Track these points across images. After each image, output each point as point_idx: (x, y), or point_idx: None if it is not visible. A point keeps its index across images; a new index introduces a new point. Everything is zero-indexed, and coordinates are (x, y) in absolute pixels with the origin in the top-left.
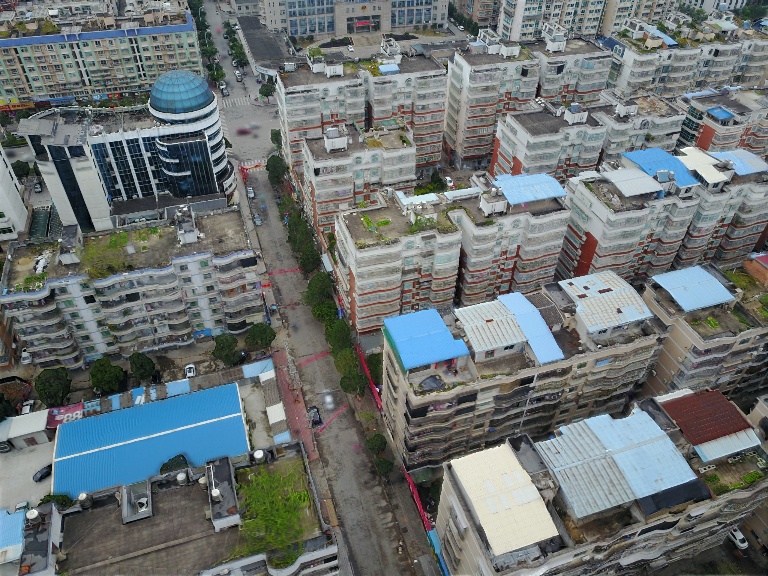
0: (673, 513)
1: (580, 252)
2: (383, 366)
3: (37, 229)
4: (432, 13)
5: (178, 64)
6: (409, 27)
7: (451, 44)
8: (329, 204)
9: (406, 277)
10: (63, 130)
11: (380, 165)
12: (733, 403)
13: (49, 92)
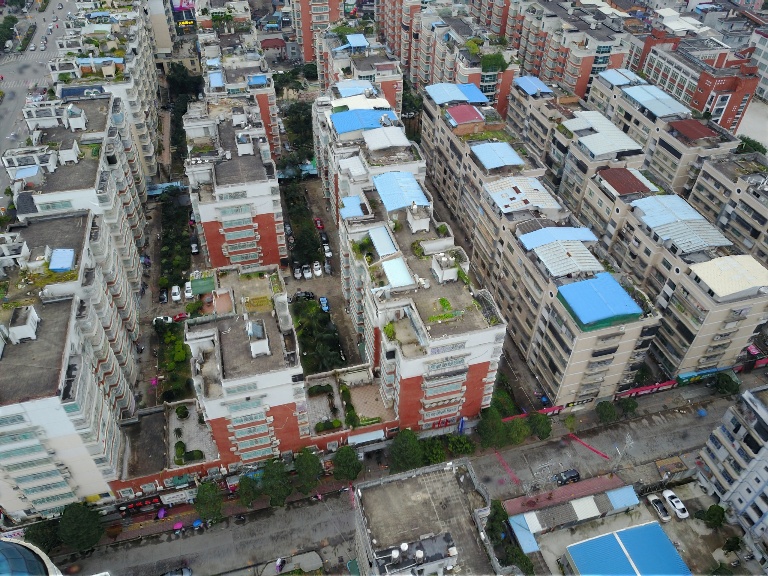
0: None
1: None
2: (574, 365)
3: None
4: None
5: None
6: None
7: None
8: None
9: None
10: None
11: None
12: None
13: None
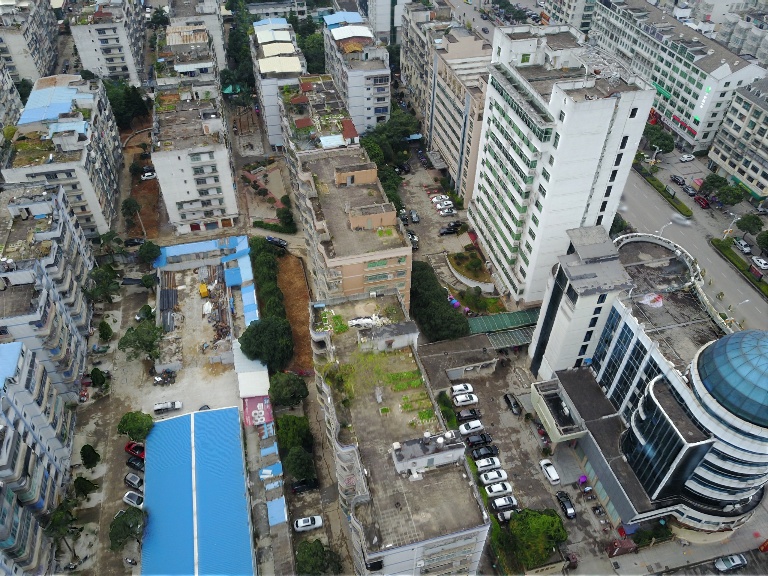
0: None
1: None
2: None
3: None
4: None
5: None
6: None
7: None
8: None
9: None
10: (606, 268)
11: None
12: None
13: None
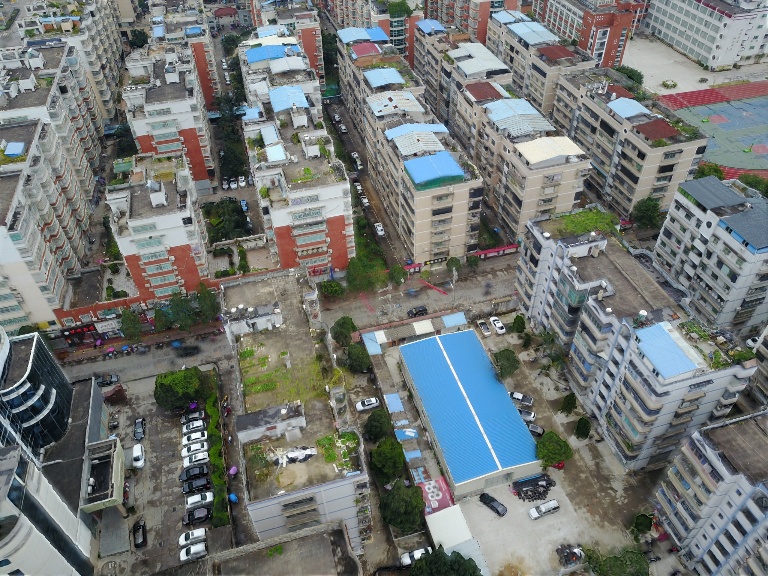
0: (540, 111)
1: None
2: (419, 223)
3: None
4: None
5: None
6: None
7: None
8: None
9: None
10: None
11: None
12: None
13: None
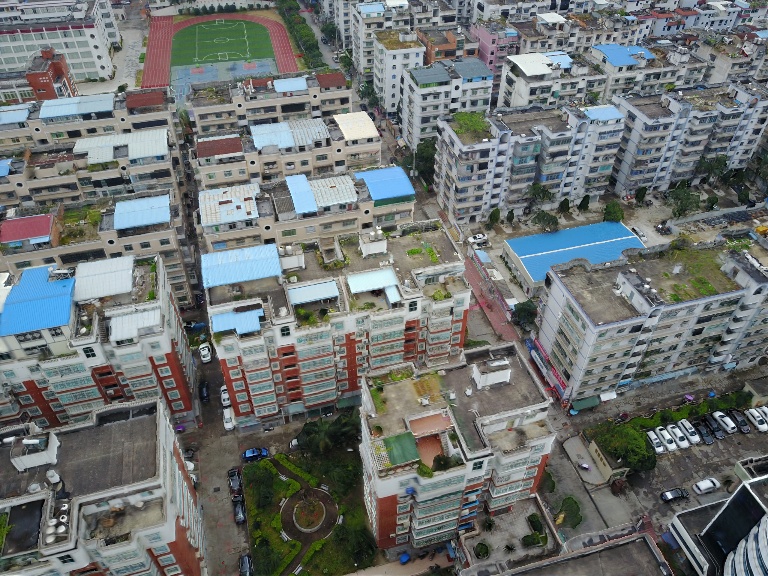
0: None
1: (180, 328)
2: None
3: None
4: None
5: None
6: None
7: None
8: None
9: None
10: None
11: None
12: (191, 159)
13: None
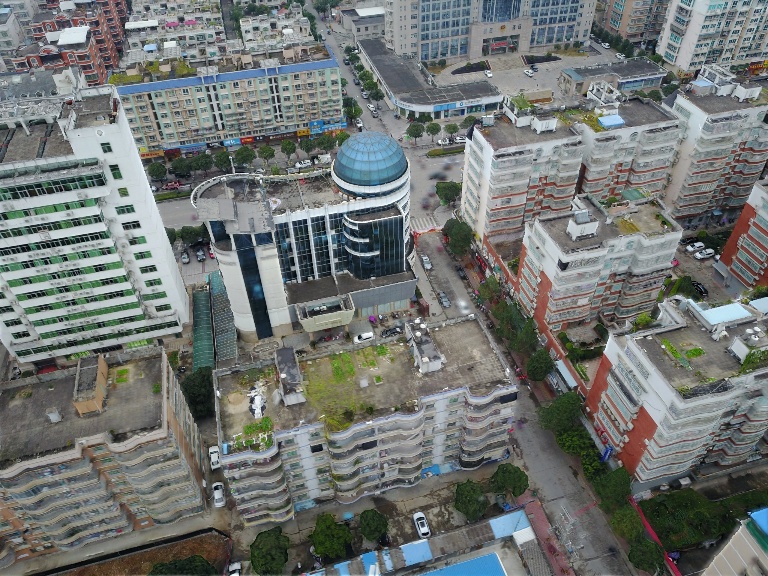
0: None
1: None
2: (722, 559)
3: (201, 318)
4: (575, 30)
5: (318, 103)
6: (548, 46)
7: (609, 68)
8: (567, 300)
9: (719, 421)
10: (244, 211)
11: (633, 252)
12: None
13: (180, 139)
